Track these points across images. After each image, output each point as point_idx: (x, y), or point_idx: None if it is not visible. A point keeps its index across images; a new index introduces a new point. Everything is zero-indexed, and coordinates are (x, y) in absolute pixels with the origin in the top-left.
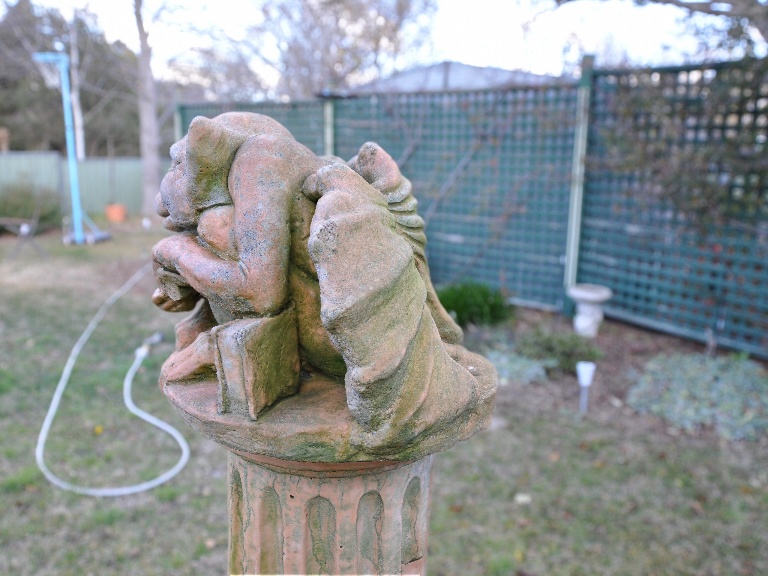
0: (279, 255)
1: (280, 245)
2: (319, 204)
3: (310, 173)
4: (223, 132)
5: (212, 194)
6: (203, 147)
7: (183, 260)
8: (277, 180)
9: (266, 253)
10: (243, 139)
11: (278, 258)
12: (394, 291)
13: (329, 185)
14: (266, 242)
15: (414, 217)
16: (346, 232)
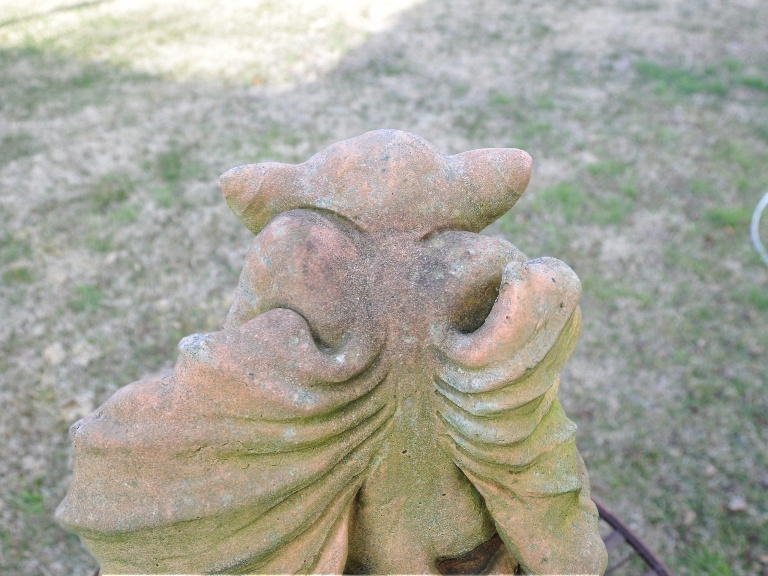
0: None
1: None
2: None
3: (287, 302)
4: (263, 193)
5: None
6: None
7: None
8: (252, 291)
9: None
10: (304, 201)
11: None
12: (124, 538)
13: None
14: None
15: (477, 426)
16: (83, 449)
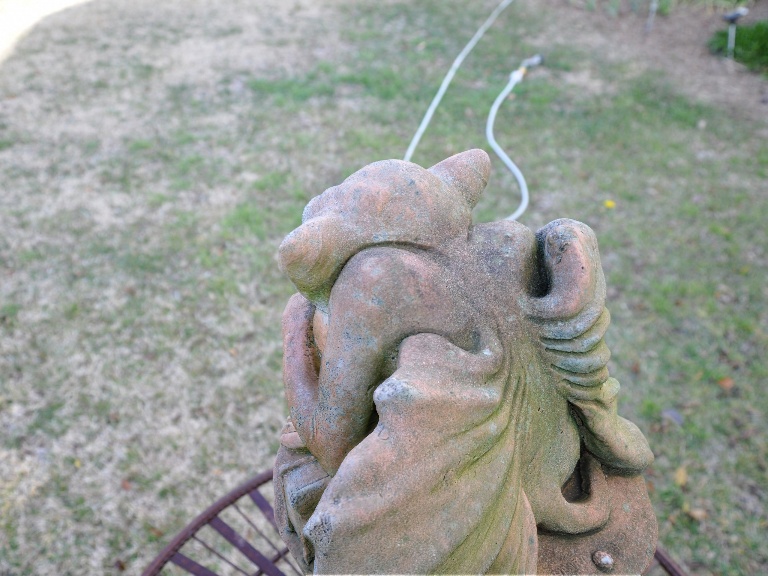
0: (351, 425)
1: (354, 415)
2: (339, 470)
3: (413, 329)
4: (325, 247)
5: (317, 302)
6: (294, 270)
7: (283, 363)
8: (366, 336)
9: (335, 421)
10: (360, 242)
11: (349, 429)
12: None
13: (381, 419)
14: (337, 410)
15: (588, 360)
16: (345, 538)
